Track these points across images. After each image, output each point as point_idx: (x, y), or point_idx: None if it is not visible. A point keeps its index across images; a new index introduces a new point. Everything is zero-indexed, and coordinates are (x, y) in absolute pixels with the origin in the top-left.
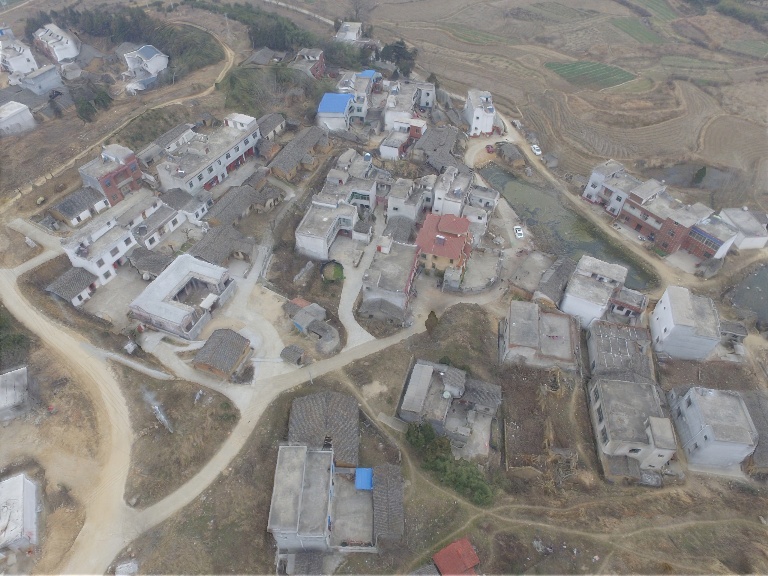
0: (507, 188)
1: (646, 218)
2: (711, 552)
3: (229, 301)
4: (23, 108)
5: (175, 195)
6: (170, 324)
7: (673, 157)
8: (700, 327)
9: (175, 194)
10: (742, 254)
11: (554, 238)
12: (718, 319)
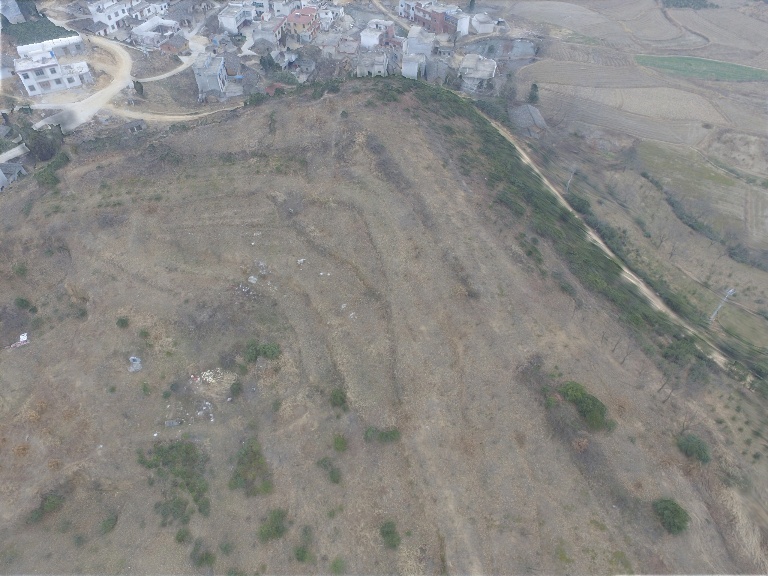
0: None
1: (425, 16)
2: None
3: None
4: None
5: None
6: (148, 38)
7: (467, 2)
8: (422, 41)
9: None
10: (479, 34)
11: None
12: (434, 39)
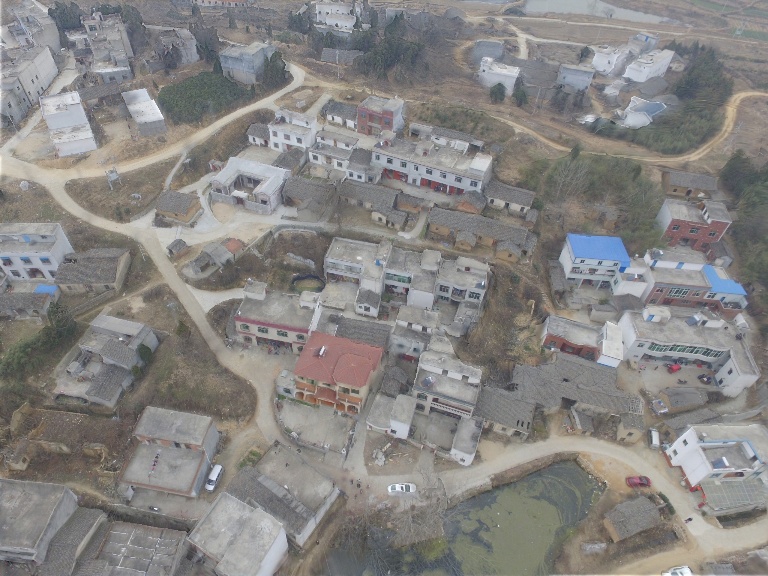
0: (537, 503)
1: None
2: None
3: (253, 212)
4: (513, 75)
5: (364, 153)
6: None
7: None
8: None
9: (365, 153)
10: None
11: (414, 559)
12: None
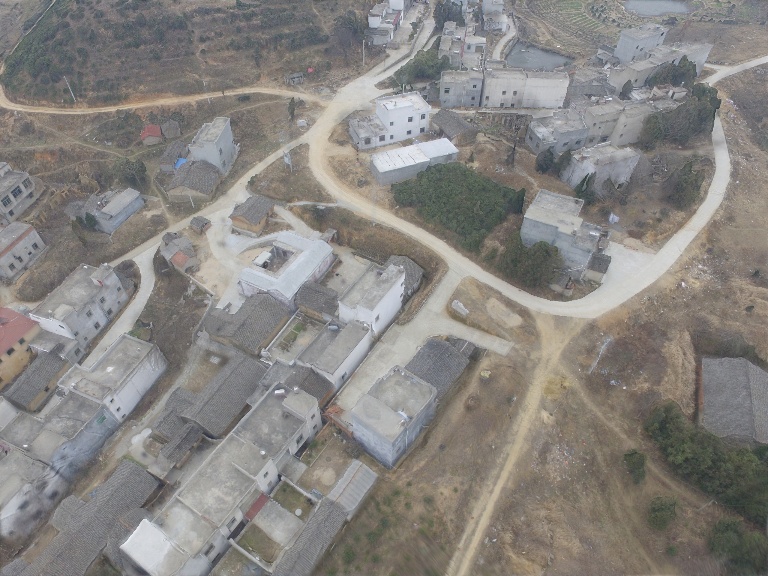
0: None
1: None
2: (33, 137)
3: None
4: None
5: (296, 380)
6: None
7: None
8: None
9: (296, 381)
10: None
11: None
12: None
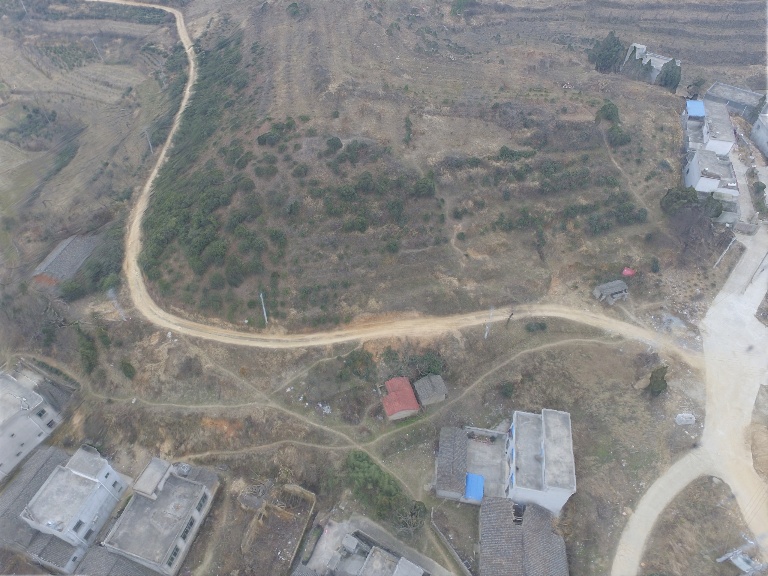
0: None
1: None
2: (198, 383)
3: None
4: None
5: None
6: None
7: None
8: None
9: None
10: None
11: None
12: None
